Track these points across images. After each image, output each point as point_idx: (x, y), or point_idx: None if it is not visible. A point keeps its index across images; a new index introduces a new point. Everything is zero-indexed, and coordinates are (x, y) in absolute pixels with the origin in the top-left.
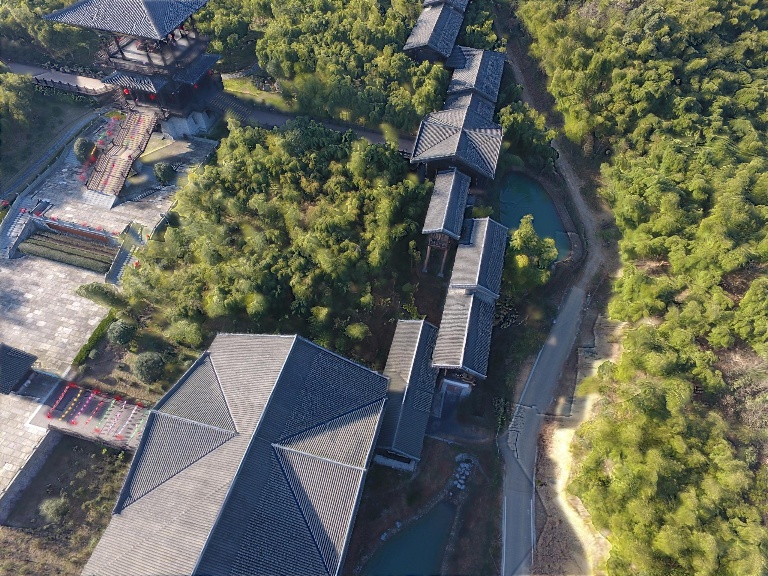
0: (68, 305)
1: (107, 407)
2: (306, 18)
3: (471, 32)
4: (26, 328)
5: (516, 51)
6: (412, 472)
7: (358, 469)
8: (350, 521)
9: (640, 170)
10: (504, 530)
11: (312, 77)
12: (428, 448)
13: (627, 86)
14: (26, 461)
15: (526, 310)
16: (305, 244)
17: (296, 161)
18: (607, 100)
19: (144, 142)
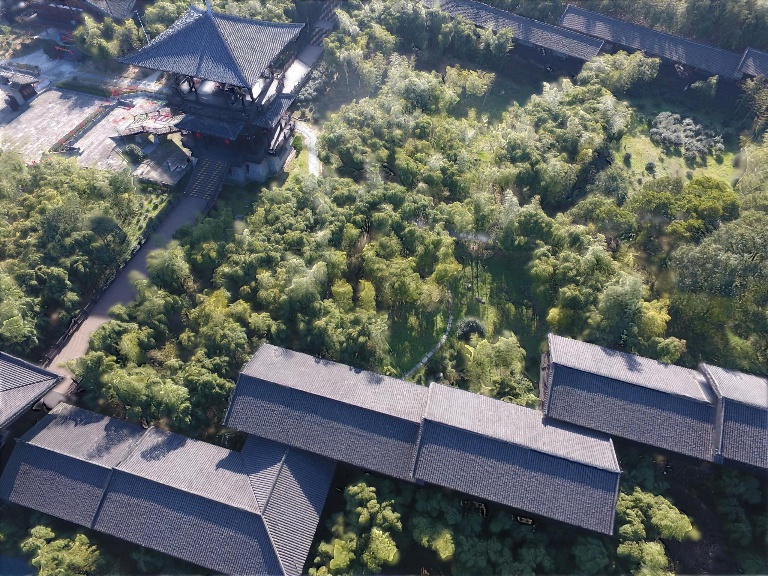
0: (31, 143)
1: None
2: (345, 207)
3: (356, 497)
4: (20, 130)
5: None
6: None
7: None
8: None
9: None
10: None
11: (198, 228)
12: None
13: None
14: None
15: None
16: None
17: (28, 226)
18: None
19: (164, 131)
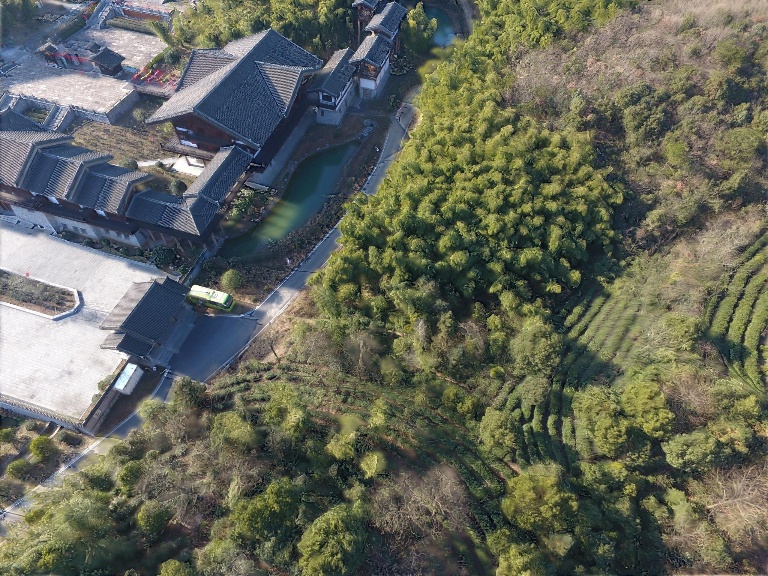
0: (138, 48)
1: (165, 85)
2: None
3: None
4: None
5: None
6: (338, 126)
7: (298, 70)
8: (293, 91)
9: None
10: (385, 144)
11: None
12: (348, 118)
13: None
14: (123, 98)
15: (420, 66)
16: (281, 8)
17: None
18: None
19: None
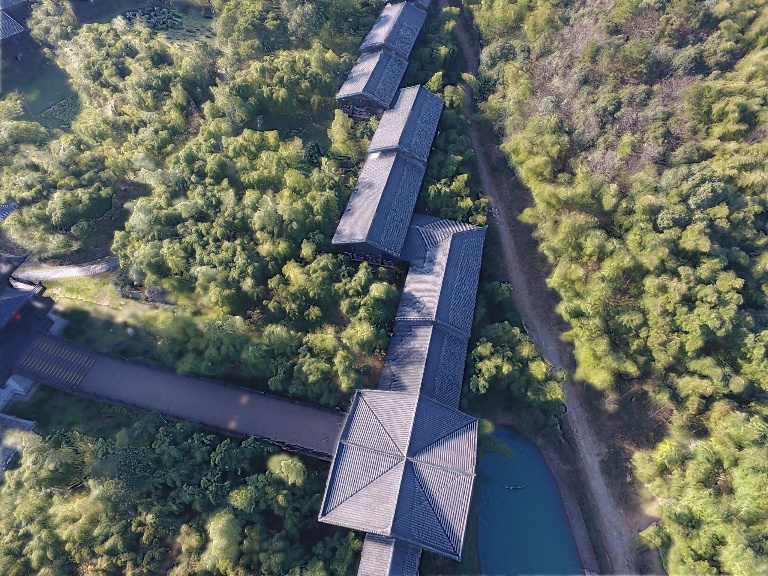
0: None
1: None
2: (190, 192)
3: (436, 194)
4: None
5: (502, 192)
6: None
7: None
8: None
9: (705, 502)
10: None
11: (181, 316)
12: None
13: (669, 308)
14: None
15: None
16: None
17: (117, 536)
18: (638, 323)
19: None
